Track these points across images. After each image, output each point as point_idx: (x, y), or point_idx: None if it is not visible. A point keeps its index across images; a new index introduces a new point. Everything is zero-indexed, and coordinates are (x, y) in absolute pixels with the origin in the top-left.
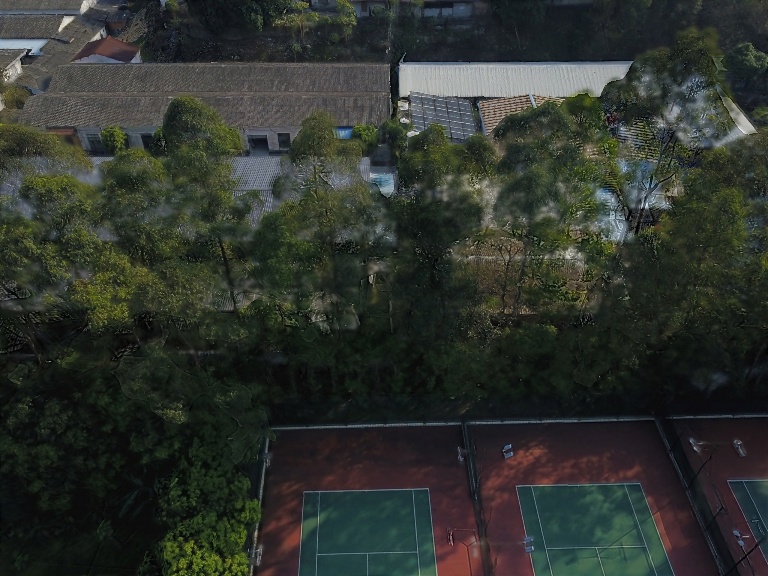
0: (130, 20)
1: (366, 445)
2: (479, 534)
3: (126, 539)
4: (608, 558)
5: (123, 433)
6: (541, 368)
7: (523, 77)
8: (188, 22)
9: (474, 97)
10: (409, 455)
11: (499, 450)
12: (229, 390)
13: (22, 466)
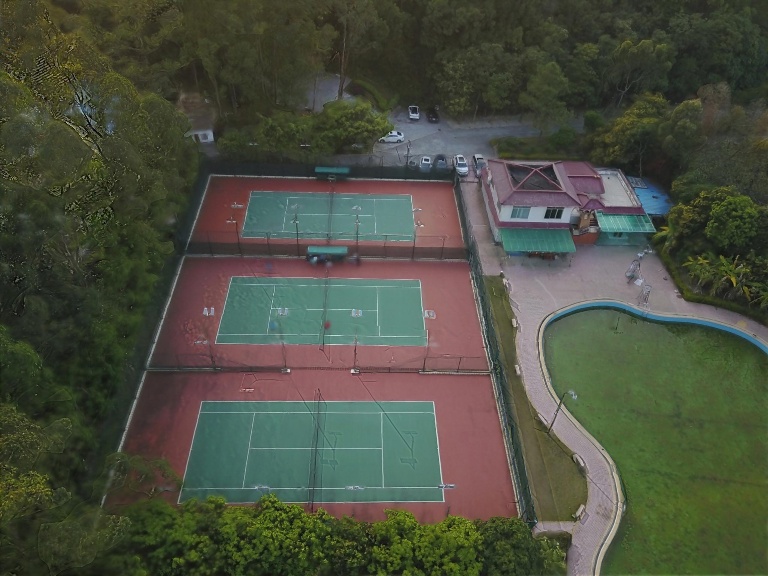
0: None
1: (142, 448)
2: (249, 371)
3: None
4: (280, 304)
5: None
6: (134, 284)
7: None
8: None
9: None
10: (165, 414)
11: (180, 349)
12: (109, 469)
13: None
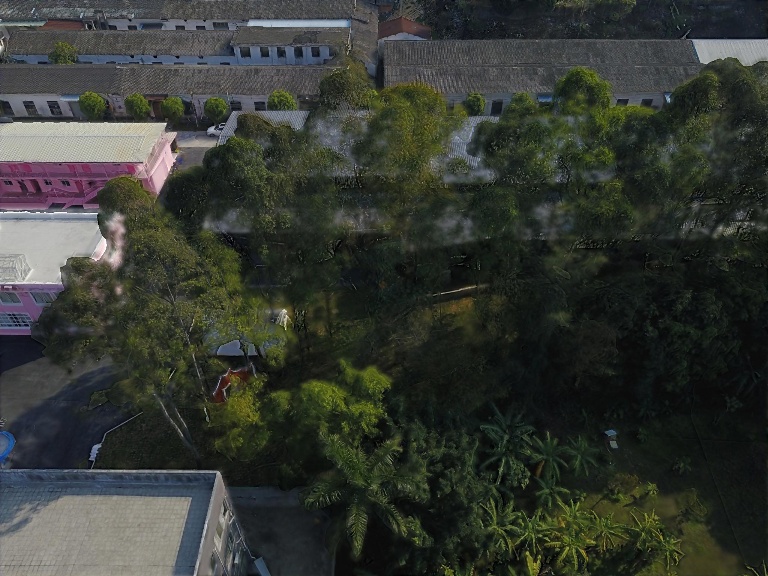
0: (396, 4)
1: None
2: None
3: (712, 420)
4: None
5: (755, 321)
6: None
7: None
8: (472, 4)
9: None
10: None
11: None
12: None
13: (687, 346)
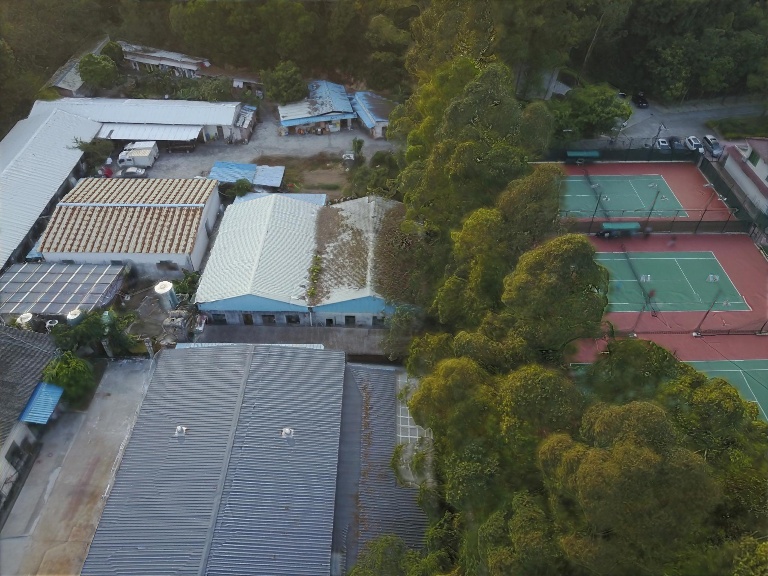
0: None
1: None
2: None
3: None
4: None
5: None
6: None
7: (2, 206)
8: None
9: (9, 258)
10: None
11: None
12: None
13: None
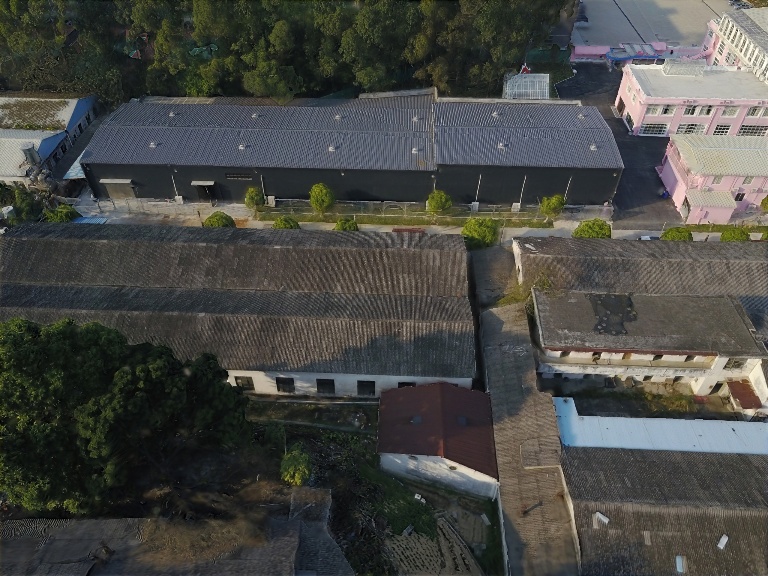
0: None
1: None
2: None
3: None
4: None
5: None
6: None
7: None
8: None
9: None
10: None
11: None
12: None
13: None
